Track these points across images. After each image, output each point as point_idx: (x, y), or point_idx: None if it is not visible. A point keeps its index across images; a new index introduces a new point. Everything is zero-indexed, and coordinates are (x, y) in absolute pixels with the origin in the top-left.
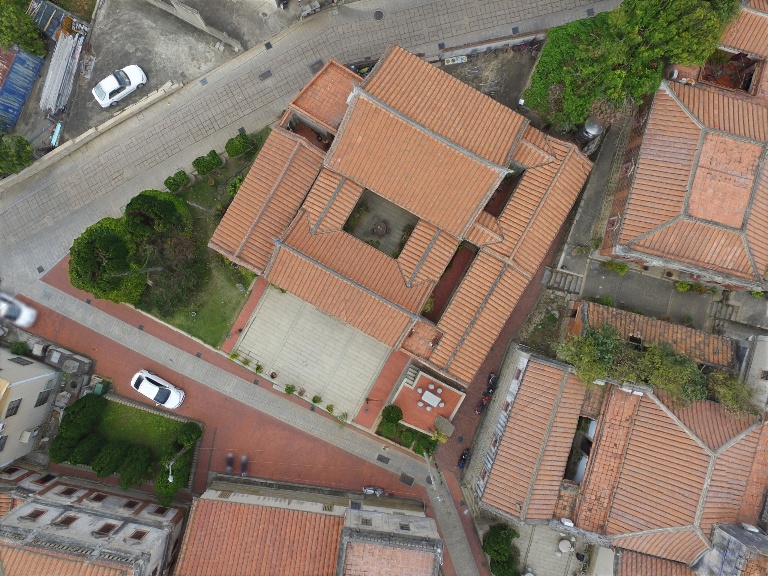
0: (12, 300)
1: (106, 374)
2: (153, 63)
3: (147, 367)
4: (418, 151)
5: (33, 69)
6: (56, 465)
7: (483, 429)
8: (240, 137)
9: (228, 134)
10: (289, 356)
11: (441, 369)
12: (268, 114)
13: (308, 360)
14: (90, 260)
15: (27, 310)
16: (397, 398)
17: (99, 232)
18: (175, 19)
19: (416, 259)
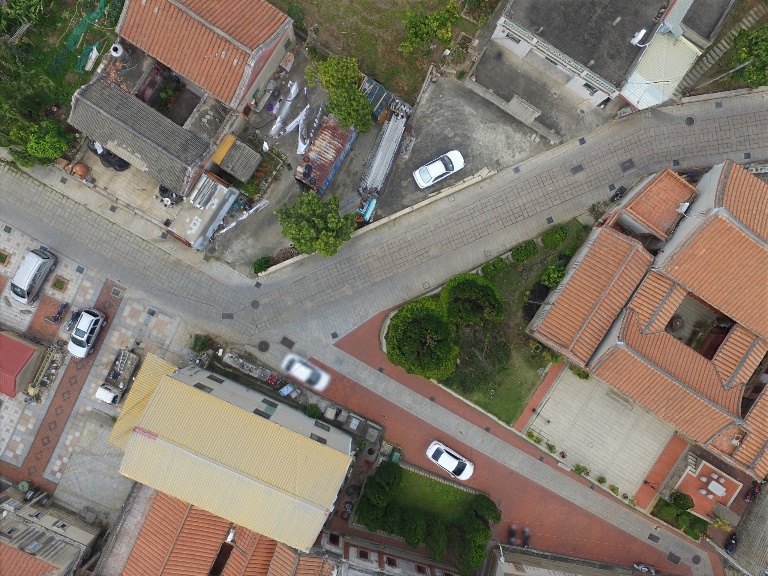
0: (304, 363)
1: (395, 441)
2: (470, 149)
3: (437, 438)
4: (759, 267)
5: (350, 144)
6: (338, 524)
7: (755, 517)
8: (561, 230)
9: (536, 222)
10: (577, 437)
11: (748, 467)
12: (576, 206)
13: (594, 442)
14: (418, 340)
15: (319, 374)
16: (680, 484)
17: (419, 311)
18: (496, 109)
19: (733, 363)
